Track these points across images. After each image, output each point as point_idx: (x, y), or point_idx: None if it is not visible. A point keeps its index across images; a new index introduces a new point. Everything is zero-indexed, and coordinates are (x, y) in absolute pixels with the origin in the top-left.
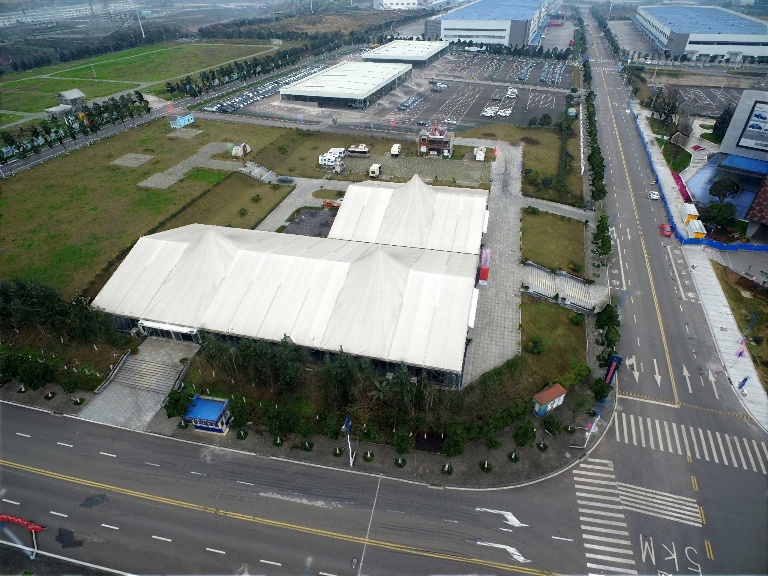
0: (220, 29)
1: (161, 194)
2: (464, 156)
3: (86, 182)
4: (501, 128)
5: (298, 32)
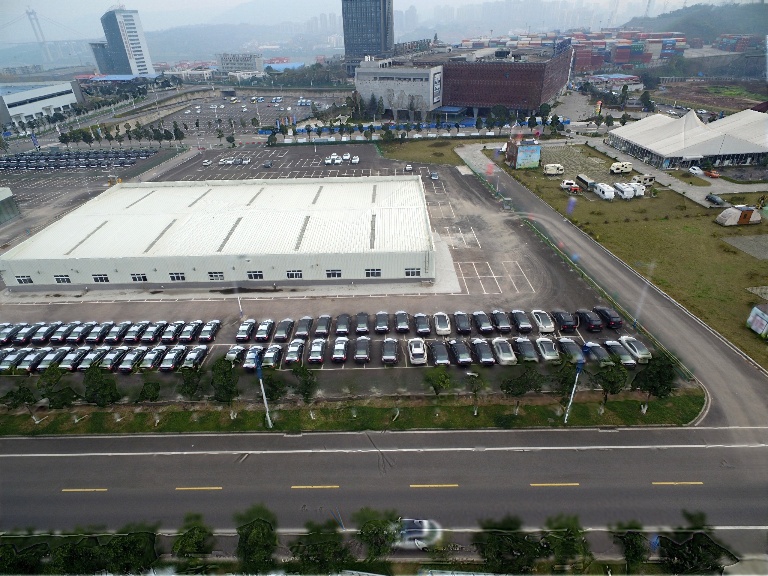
0: None
1: None
2: None
3: None
4: (402, 155)
5: None
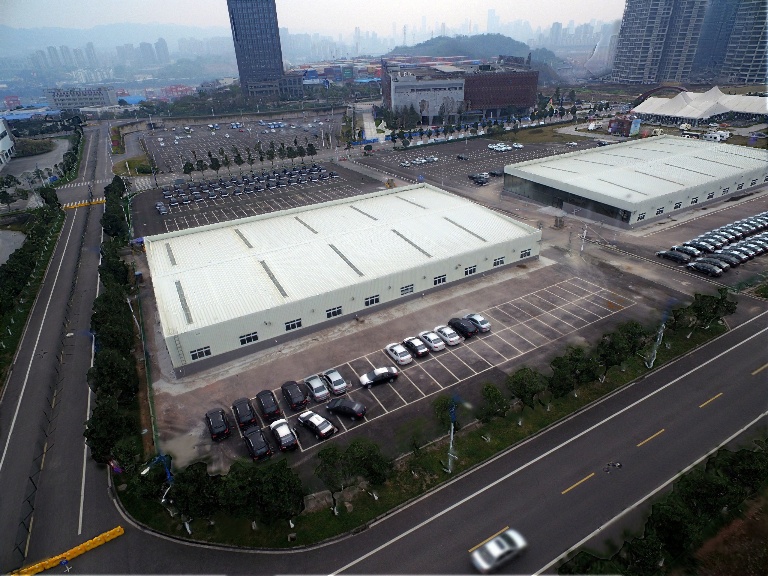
0: None
1: None
2: (605, 130)
3: None
4: (532, 140)
5: None
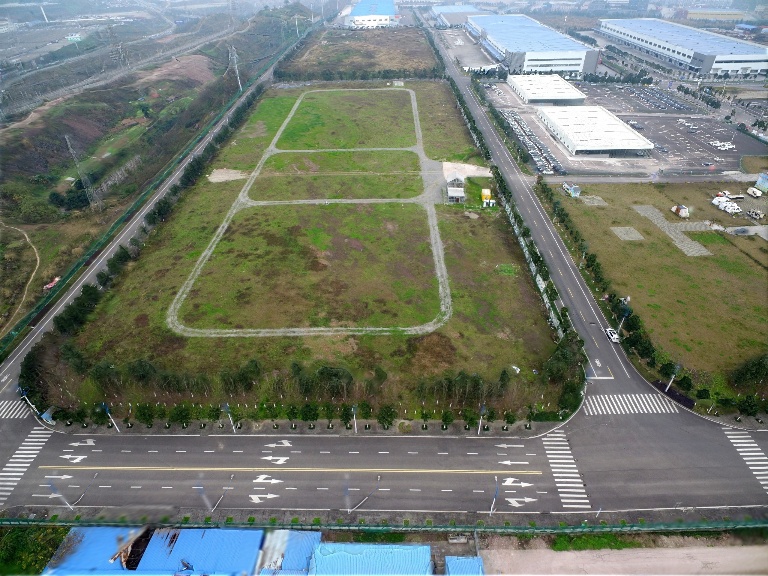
0: (302, 70)
1: (724, 260)
2: None
3: (654, 260)
4: (755, 160)
5: (395, 70)
